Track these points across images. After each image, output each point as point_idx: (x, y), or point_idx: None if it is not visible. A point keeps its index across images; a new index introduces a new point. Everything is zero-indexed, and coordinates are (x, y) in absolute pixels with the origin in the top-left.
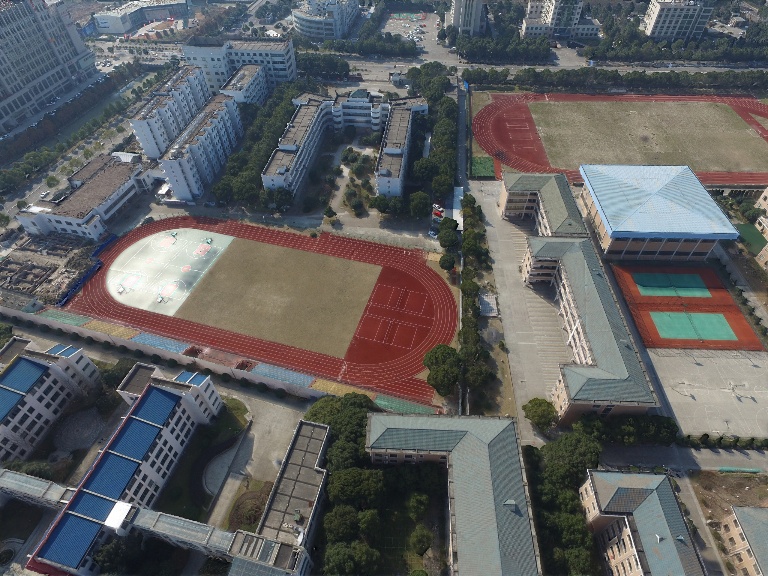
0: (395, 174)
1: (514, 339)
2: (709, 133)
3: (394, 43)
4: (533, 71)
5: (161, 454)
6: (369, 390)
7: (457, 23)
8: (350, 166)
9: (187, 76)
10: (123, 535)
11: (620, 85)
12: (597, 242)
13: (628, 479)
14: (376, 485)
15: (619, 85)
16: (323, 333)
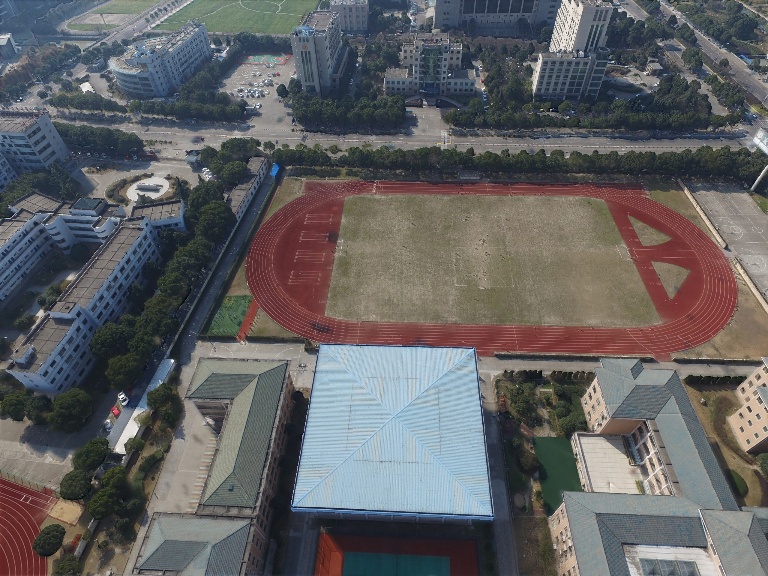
0: (39, 362)
1: None
2: (563, 252)
3: None
4: (359, 152)
5: None
6: None
7: None
8: None
9: None
10: None
11: (474, 169)
12: None
13: None
14: None
15: (473, 169)
16: None
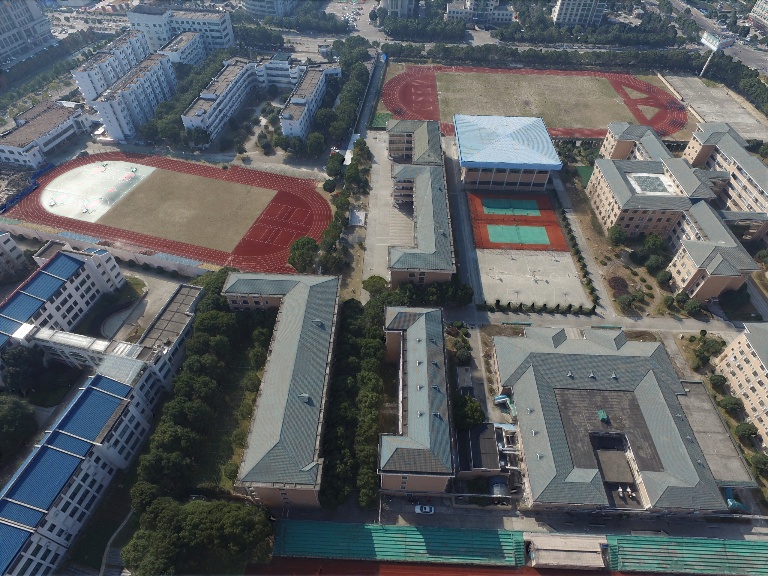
0: (296, 118)
1: (373, 241)
2: (582, 100)
3: (328, 21)
4: (443, 46)
5: (66, 304)
6: (245, 271)
7: (387, 5)
8: (267, 117)
9: (129, 38)
10: (27, 346)
11: (519, 61)
12: None
13: (410, 309)
14: (228, 320)
15: (518, 61)
16: (218, 235)
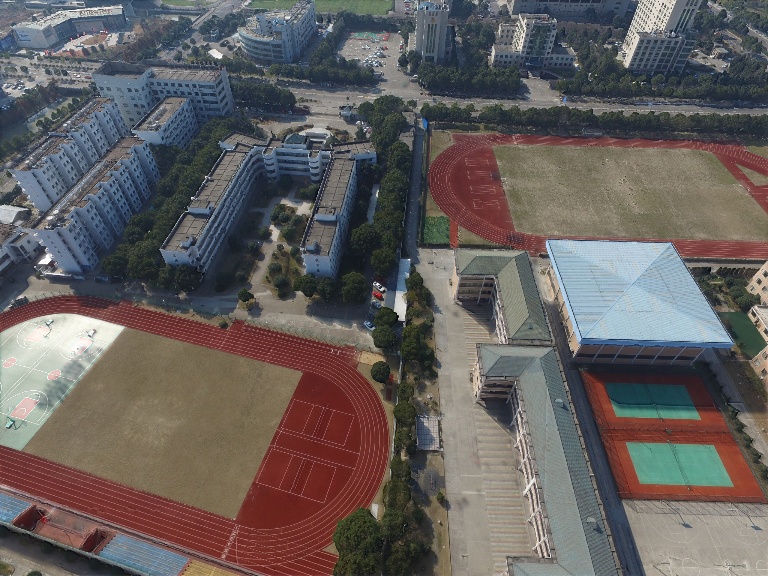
0: (325, 250)
1: (457, 486)
2: (693, 189)
3: (349, 70)
4: (500, 109)
5: None
6: None
7: (420, 48)
8: (280, 227)
9: (94, 111)
10: None
11: (595, 126)
12: (565, 338)
13: None
14: None
15: (594, 126)
16: (214, 478)
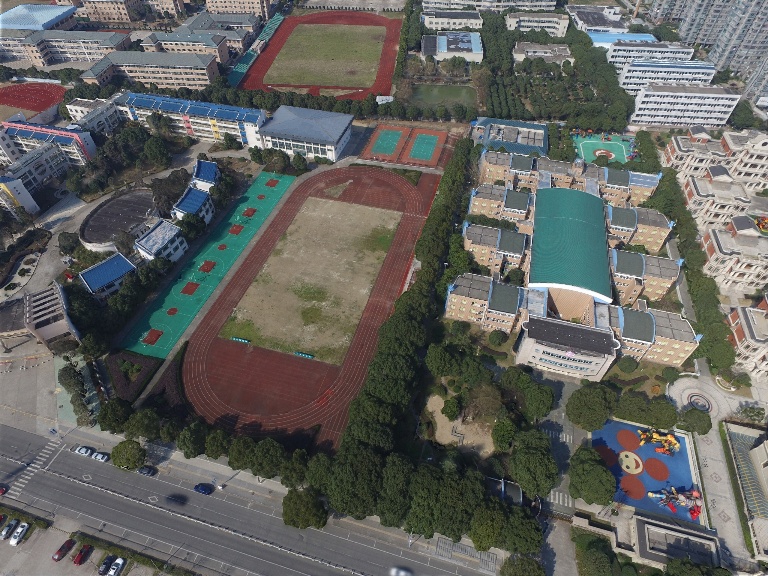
0: None
1: None
2: None
3: None
4: None
5: None
6: None
7: None
8: None
9: None
10: None
11: None
12: None
13: None
14: None
15: None
16: None
